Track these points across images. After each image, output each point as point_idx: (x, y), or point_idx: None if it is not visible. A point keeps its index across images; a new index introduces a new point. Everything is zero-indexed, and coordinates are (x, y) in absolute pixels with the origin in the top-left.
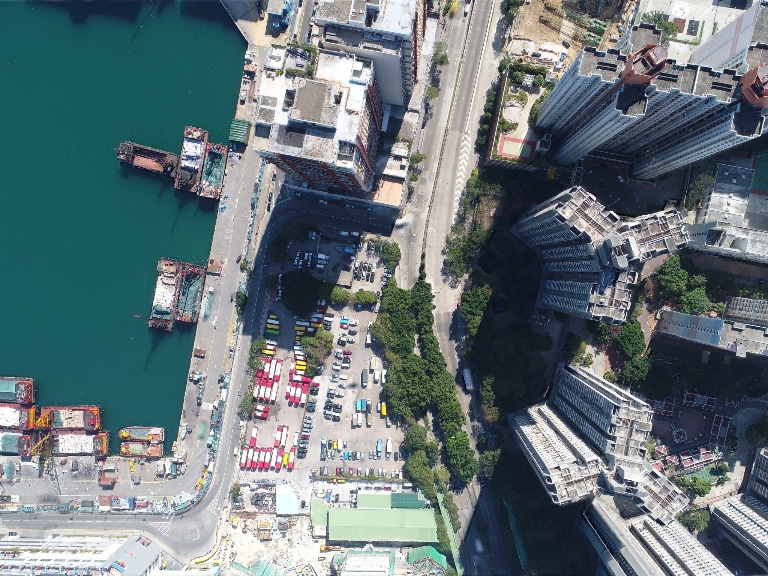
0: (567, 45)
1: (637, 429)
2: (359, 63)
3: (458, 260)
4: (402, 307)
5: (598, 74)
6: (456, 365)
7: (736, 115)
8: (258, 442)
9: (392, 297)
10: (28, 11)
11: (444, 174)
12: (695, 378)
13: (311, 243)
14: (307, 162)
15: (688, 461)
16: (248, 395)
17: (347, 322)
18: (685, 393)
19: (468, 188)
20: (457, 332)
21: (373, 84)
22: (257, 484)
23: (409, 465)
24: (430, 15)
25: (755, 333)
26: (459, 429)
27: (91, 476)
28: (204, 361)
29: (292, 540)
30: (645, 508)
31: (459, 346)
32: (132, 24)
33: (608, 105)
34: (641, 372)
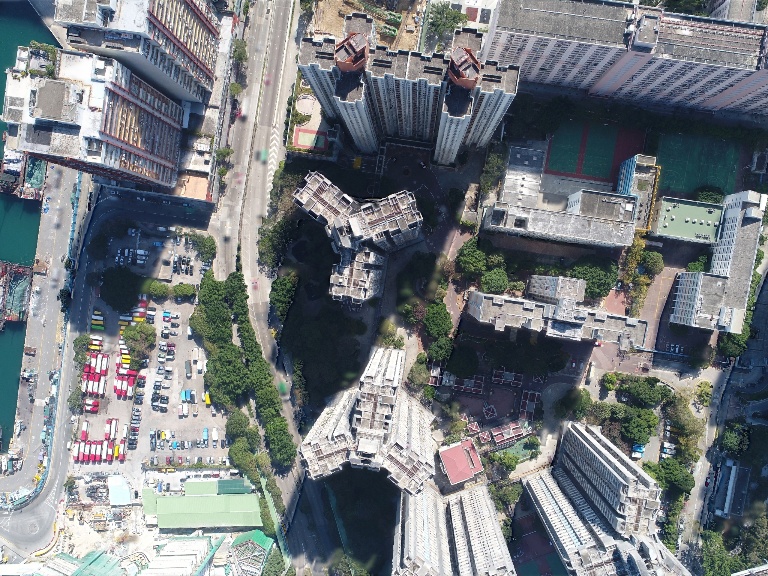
0: None
1: (380, 403)
2: (100, 62)
3: (268, 250)
4: (214, 298)
5: (316, 63)
6: (276, 353)
7: (448, 97)
8: (90, 436)
9: (206, 289)
10: None
11: (255, 167)
12: (500, 356)
13: (131, 240)
14: (63, 159)
15: (500, 437)
16: (75, 390)
17: (169, 315)
18: (494, 371)
19: (274, 180)
20: (275, 320)
21: (130, 82)
22: (90, 477)
23: (231, 452)
24: (225, 14)
25: (515, 307)
26: (277, 415)
27: None
28: (35, 359)
29: (127, 530)
30: (394, 479)
31: (278, 334)
32: None
33: None
34: (445, 352)
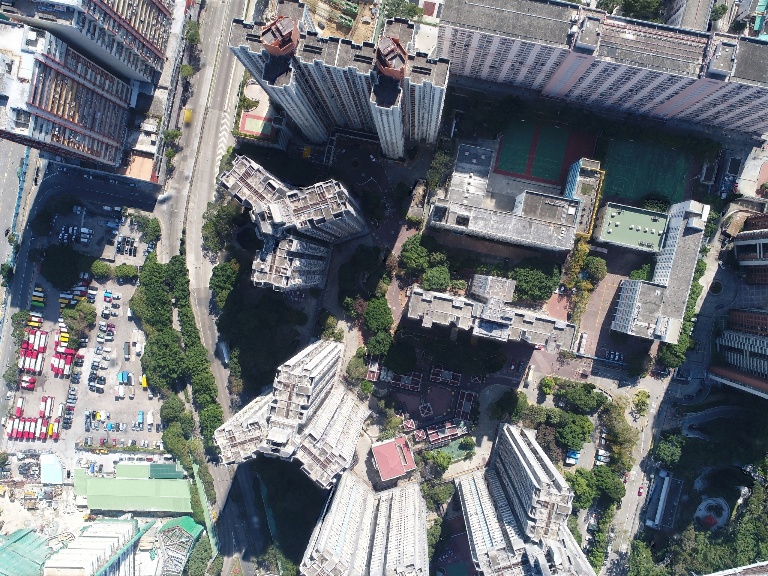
0: (322, 26)
1: (296, 392)
2: (32, 33)
3: (212, 235)
4: (154, 280)
5: (246, 45)
6: (216, 339)
7: (377, 87)
8: (25, 413)
9: (147, 271)
10: None
11: (204, 151)
12: (438, 354)
13: (76, 217)
14: None
15: (434, 435)
16: (12, 366)
17: (110, 295)
18: (432, 369)
19: (220, 165)
20: (217, 307)
21: (65, 55)
22: (23, 454)
23: (165, 436)
24: None
25: (444, 304)
26: (213, 401)
27: None
28: None
29: (58, 509)
30: (306, 470)
31: None
32: None
33: None
34: (383, 347)
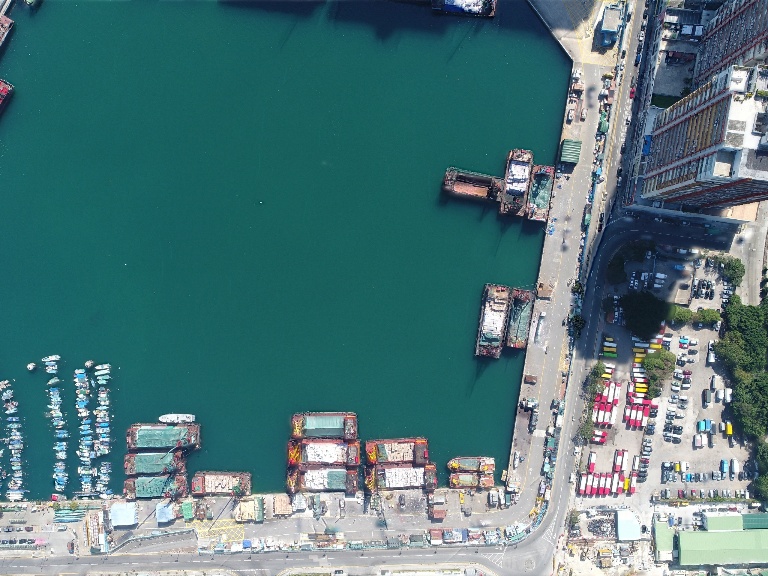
0: None
1: None
2: None
3: None
4: (757, 324)
5: None
6: None
7: None
8: (594, 468)
9: (744, 315)
10: (339, 38)
11: None
12: None
13: (646, 262)
14: None
15: None
16: (589, 421)
17: (687, 342)
18: None
19: None
20: None
21: None
22: (596, 510)
23: (763, 485)
24: None
25: None
26: None
27: (419, 509)
28: (535, 387)
29: (633, 566)
30: None
31: None
32: (447, 47)
33: None
34: None
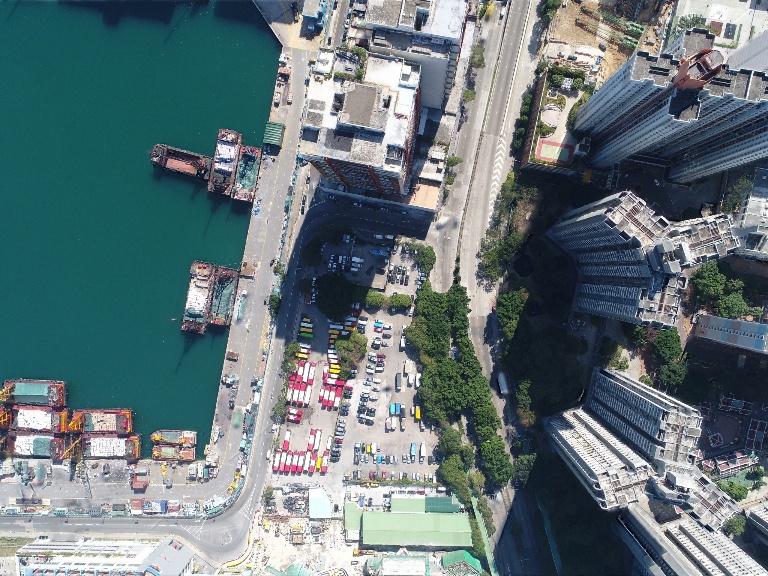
0: (603, 48)
1: (686, 435)
2: (408, 67)
3: (494, 264)
4: (438, 311)
5: (651, 79)
6: (490, 369)
7: None
8: (291, 446)
9: (427, 301)
10: (61, 13)
11: (479, 177)
12: (732, 382)
13: (345, 246)
14: (354, 166)
15: (724, 465)
16: (282, 398)
17: (381, 325)
18: (721, 397)
19: (504, 191)
20: (492, 336)
21: (419, 88)
22: (290, 488)
23: (444, 469)
24: None
25: None
26: (494, 433)
27: (123, 479)
28: (237, 364)
29: (325, 544)
30: (694, 514)
31: (493, 350)
32: (165, 26)
33: (658, 110)
34: (678, 376)
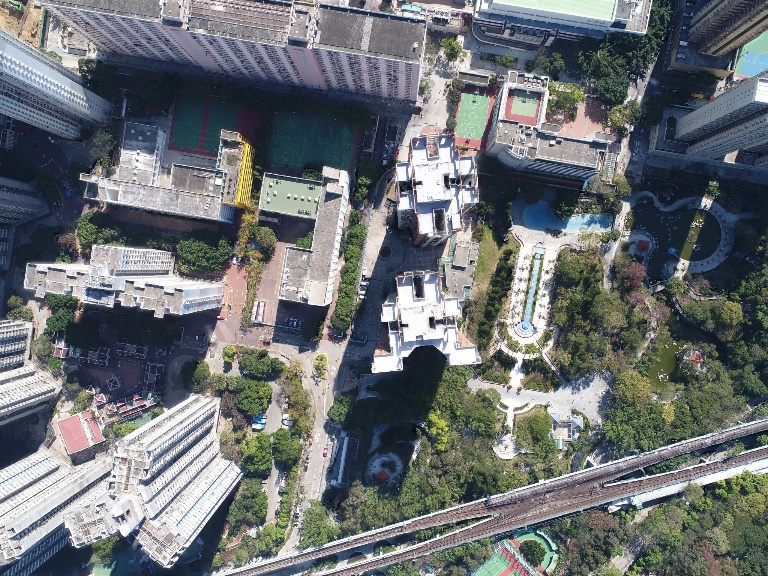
0: None
1: None
2: None
3: None
4: None
5: None
6: None
7: None
8: None
9: None
10: None
11: None
12: (120, 328)
13: None
14: None
15: (124, 408)
16: None
17: None
18: None
19: None
20: None
21: None
22: None
23: None
24: None
25: (59, 275)
26: None
27: None
28: None
29: None
30: None
31: None
32: None
33: None
34: (60, 323)
